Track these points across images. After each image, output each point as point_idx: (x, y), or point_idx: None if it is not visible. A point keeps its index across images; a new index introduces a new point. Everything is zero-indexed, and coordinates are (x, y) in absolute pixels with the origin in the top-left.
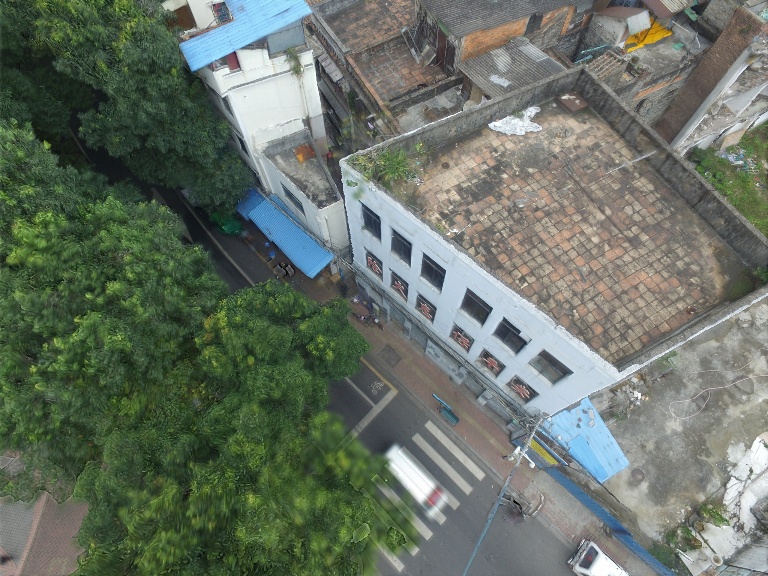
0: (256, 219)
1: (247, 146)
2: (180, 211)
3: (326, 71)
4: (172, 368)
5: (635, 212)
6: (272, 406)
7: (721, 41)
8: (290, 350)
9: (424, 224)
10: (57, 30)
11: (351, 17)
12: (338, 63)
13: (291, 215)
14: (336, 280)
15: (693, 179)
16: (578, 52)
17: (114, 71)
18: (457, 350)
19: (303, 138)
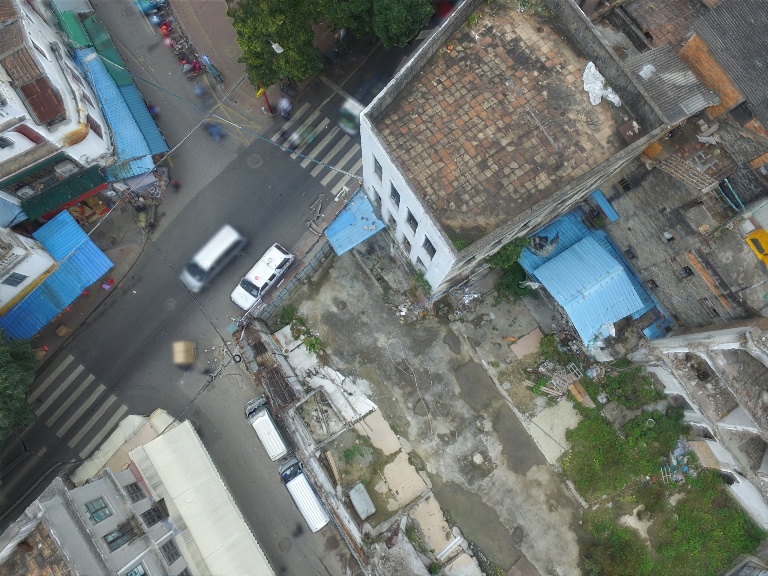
0: None
1: None
2: None
3: None
4: None
5: (512, 170)
6: None
7: None
8: None
9: None
10: None
11: None
12: None
13: None
14: None
15: None
16: (746, 205)
17: None
18: None
19: None
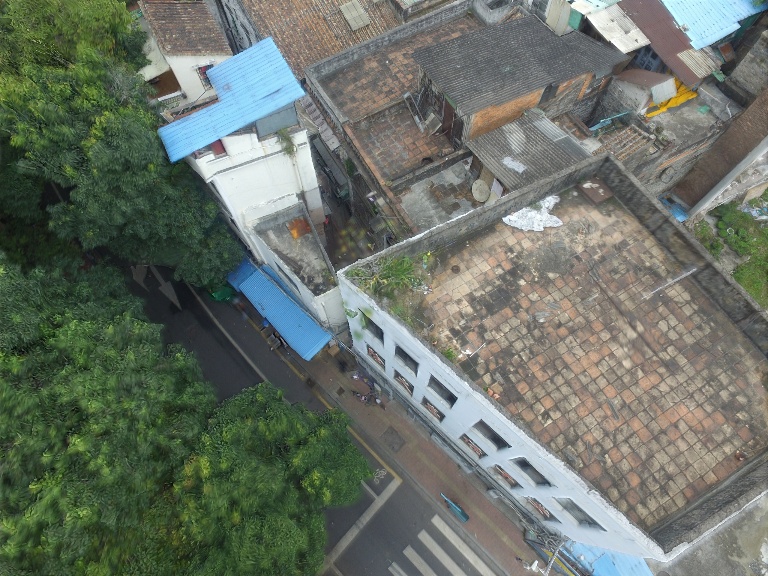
0: (248, 292)
1: (236, 223)
2: (168, 273)
3: (322, 138)
4: (149, 506)
5: (670, 328)
6: (261, 567)
7: (753, 109)
8: (282, 481)
9: (433, 355)
10: (14, 134)
11: (349, 77)
12: (335, 131)
13: (285, 288)
14: (334, 353)
15: (737, 295)
16: (595, 114)
17: (81, 173)
18: (467, 452)
19: (297, 212)
